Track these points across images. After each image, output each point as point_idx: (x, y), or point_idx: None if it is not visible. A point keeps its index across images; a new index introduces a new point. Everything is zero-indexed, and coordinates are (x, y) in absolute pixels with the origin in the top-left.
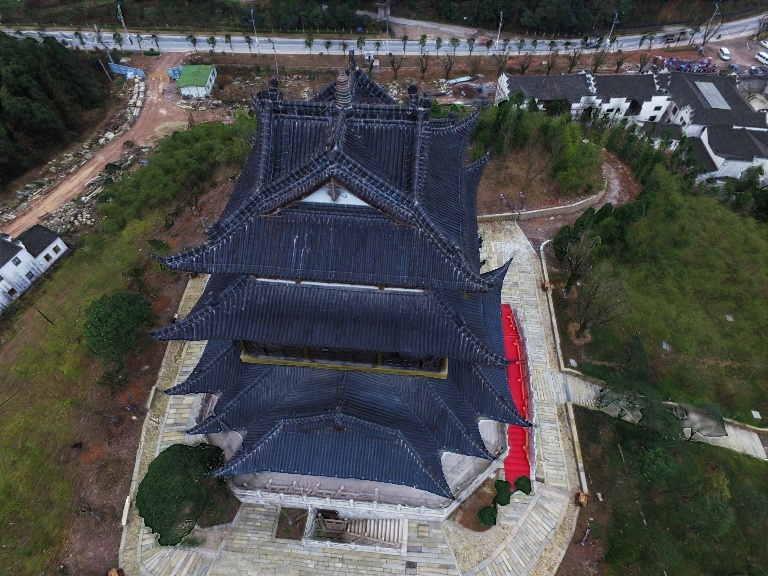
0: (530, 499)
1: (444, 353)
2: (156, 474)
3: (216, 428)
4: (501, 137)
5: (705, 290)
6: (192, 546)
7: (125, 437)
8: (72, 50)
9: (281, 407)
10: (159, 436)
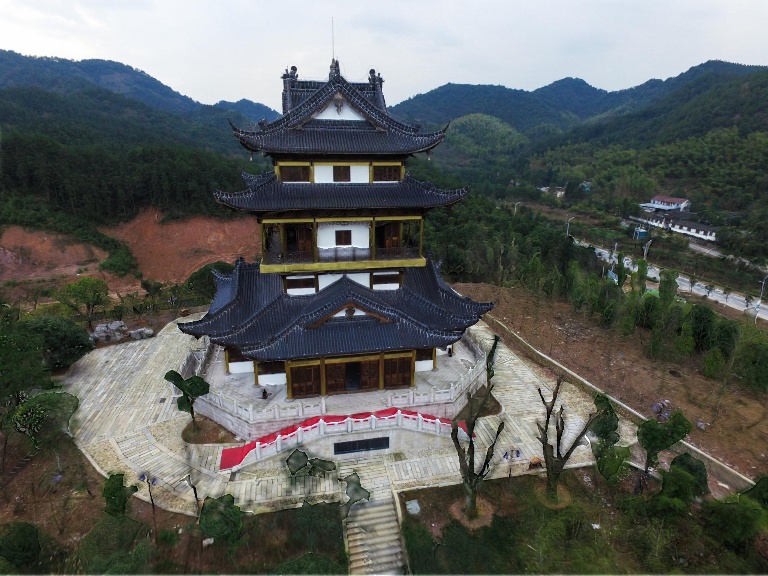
0: (210, 468)
1: None
2: None
3: None
4: (760, 360)
5: None
6: None
7: None
8: (600, 259)
9: None
10: None
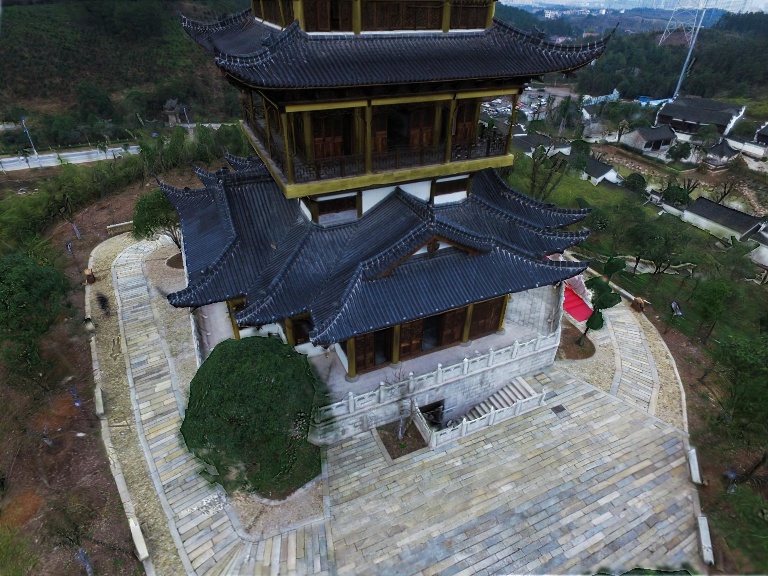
0: None
1: (538, 68)
2: (220, 369)
3: (268, 316)
4: None
5: (579, 194)
6: (281, 526)
7: (77, 461)
8: None
9: (342, 270)
10: (139, 437)
